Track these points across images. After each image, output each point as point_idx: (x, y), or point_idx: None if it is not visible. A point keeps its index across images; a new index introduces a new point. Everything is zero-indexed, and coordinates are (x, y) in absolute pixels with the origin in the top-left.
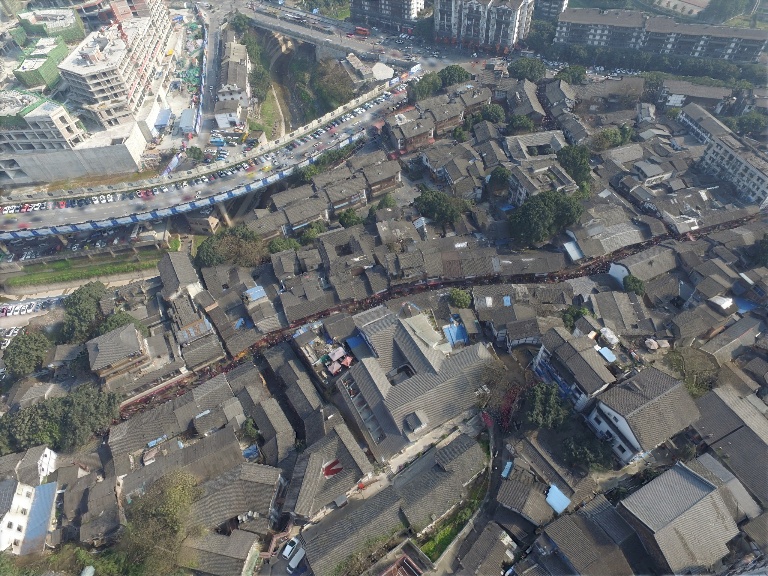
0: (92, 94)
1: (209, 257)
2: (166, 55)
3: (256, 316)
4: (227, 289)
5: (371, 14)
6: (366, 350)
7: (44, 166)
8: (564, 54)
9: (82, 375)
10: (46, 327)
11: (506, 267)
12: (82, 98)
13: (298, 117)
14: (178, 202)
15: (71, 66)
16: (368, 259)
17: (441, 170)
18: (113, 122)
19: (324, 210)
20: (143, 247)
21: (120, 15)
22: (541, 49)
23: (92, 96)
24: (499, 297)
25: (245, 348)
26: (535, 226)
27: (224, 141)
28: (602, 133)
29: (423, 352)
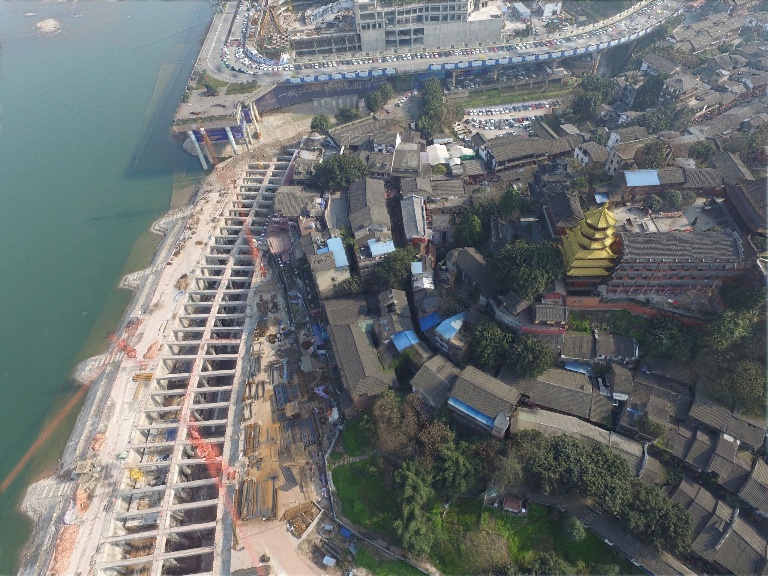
0: None
1: None
2: None
3: (730, 84)
4: None
5: None
6: None
7: (440, 35)
8: None
9: (654, 105)
10: None
11: None
12: None
13: None
14: None
15: None
16: None
17: (767, 25)
18: (484, 5)
19: None
20: (552, 81)
21: None
22: None
23: None
24: None
25: (730, 101)
26: None
27: (559, 22)
28: None
29: None
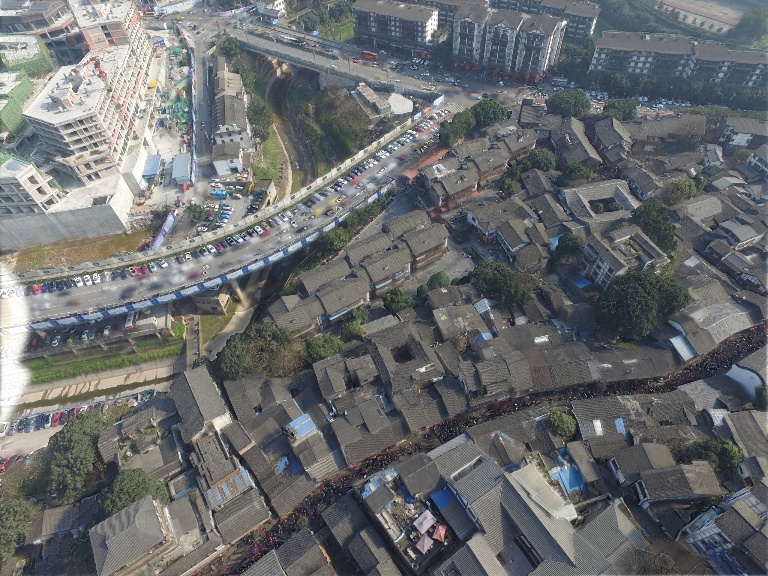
0: (67, 145)
1: (233, 368)
2: (149, 87)
3: (306, 458)
4: (261, 413)
5: (379, 36)
6: (459, 510)
7: (11, 233)
8: (602, 83)
9: (83, 571)
10: (27, 482)
11: (605, 372)
12: (54, 148)
13: (305, 156)
14: (182, 281)
15: (39, 112)
16: (436, 368)
17: (493, 232)
18: (93, 176)
19: (365, 293)
20: (140, 336)
21: (94, 44)
22: (575, 77)
23: (67, 147)
24: (609, 420)
25: (295, 504)
26: (637, 320)
27: (226, 193)
28: (674, 184)
29: (547, 529)
